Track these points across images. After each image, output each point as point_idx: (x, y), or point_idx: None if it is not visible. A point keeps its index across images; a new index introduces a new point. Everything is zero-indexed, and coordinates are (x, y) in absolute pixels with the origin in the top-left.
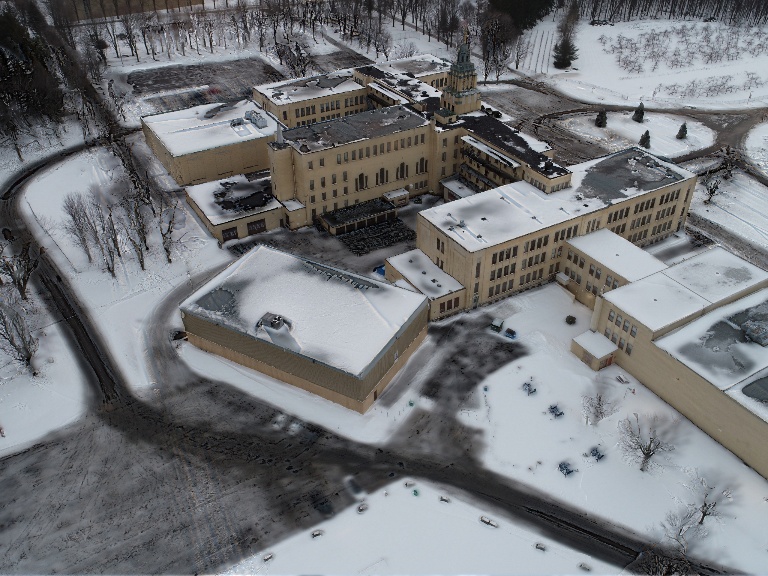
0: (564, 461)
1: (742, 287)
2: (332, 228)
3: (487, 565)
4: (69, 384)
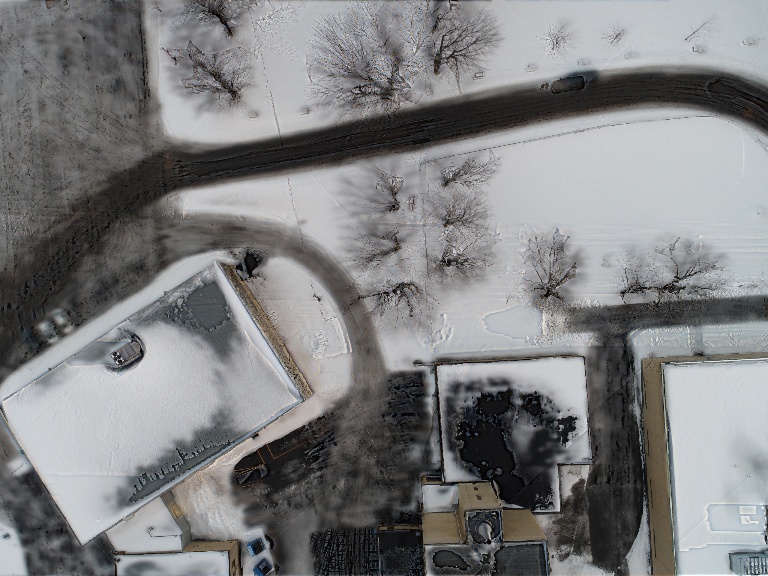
0: None
1: None
2: (380, 530)
3: None
4: (214, 130)
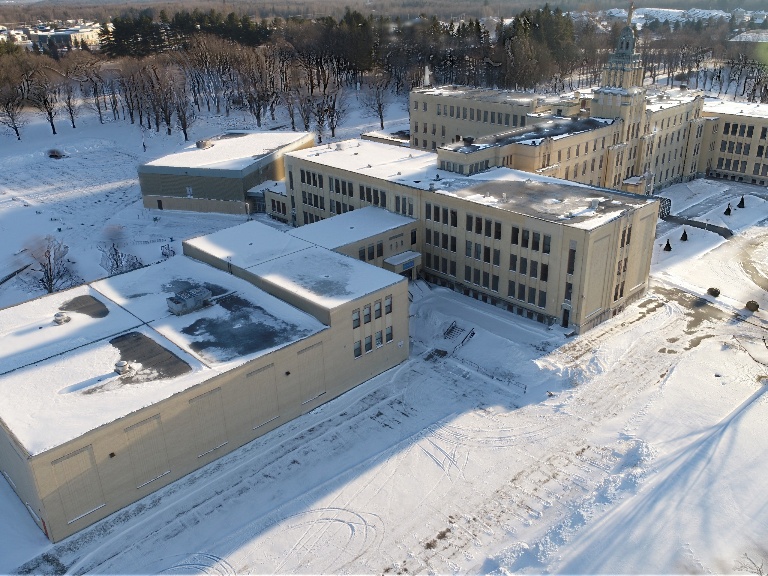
0: None
1: (291, 287)
2: None
3: None
4: None
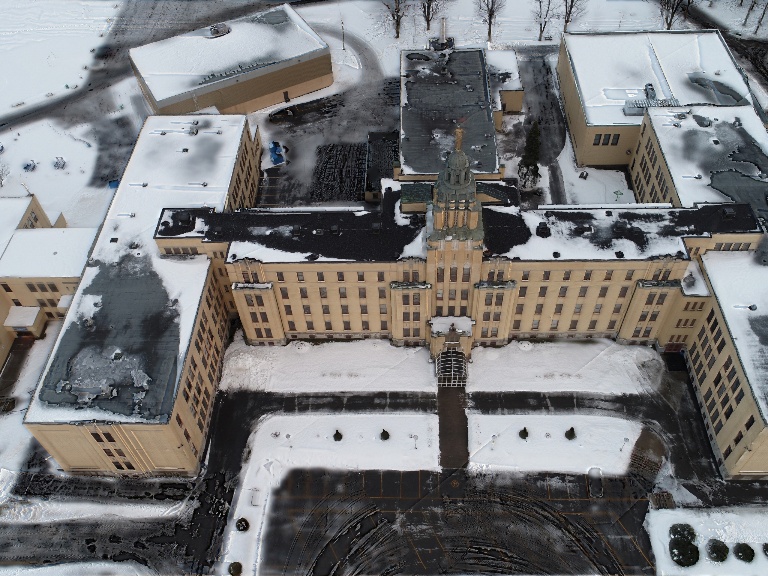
0: (4, 153)
1: None
2: None
3: (5, 96)
4: None
